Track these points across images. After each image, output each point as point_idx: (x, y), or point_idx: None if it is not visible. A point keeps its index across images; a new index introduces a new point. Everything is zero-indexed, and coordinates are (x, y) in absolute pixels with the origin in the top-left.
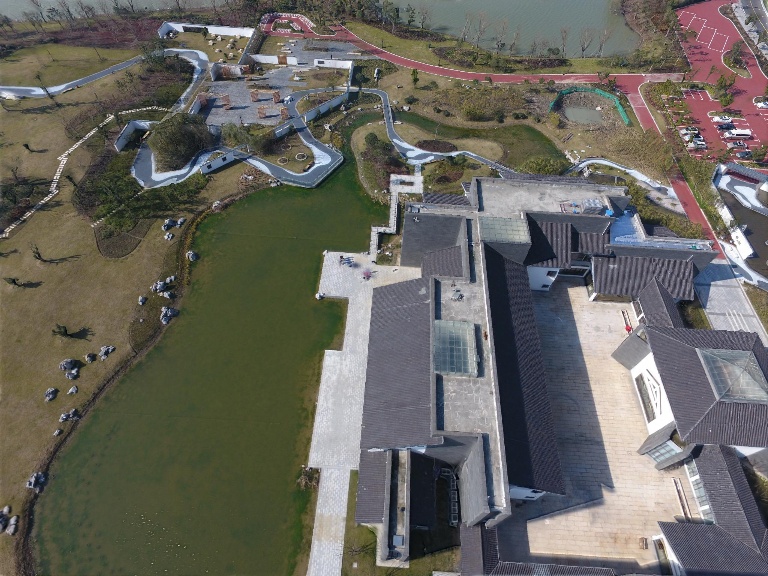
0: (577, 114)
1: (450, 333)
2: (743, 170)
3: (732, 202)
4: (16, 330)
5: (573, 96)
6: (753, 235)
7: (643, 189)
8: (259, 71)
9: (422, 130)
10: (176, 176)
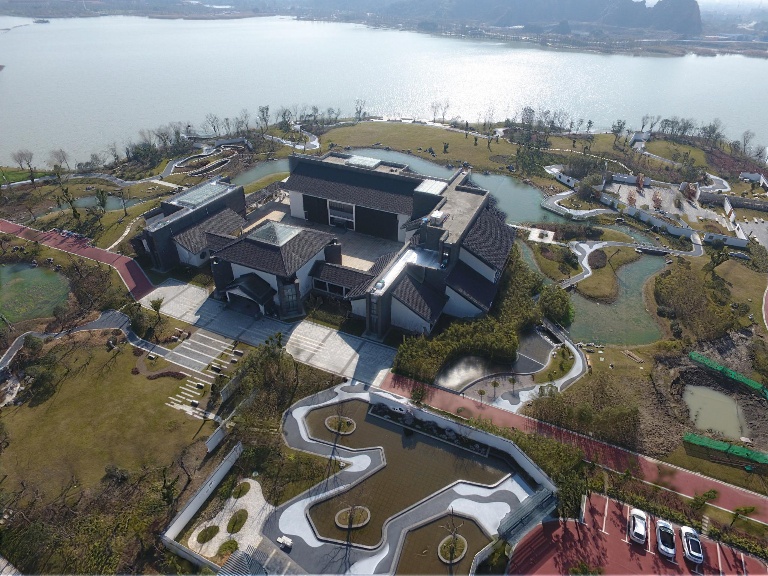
0: (718, 406)
1: (371, 161)
2: (531, 505)
3: (471, 469)
4: (453, 143)
5: (767, 411)
6: (401, 444)
7: (498, 343)
8: (707, 206)
9: (629, 262)
10: (555, 173)
